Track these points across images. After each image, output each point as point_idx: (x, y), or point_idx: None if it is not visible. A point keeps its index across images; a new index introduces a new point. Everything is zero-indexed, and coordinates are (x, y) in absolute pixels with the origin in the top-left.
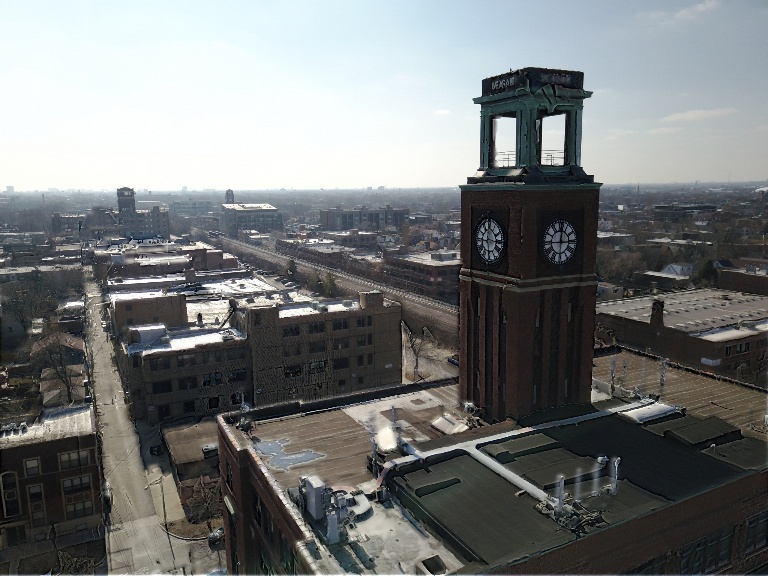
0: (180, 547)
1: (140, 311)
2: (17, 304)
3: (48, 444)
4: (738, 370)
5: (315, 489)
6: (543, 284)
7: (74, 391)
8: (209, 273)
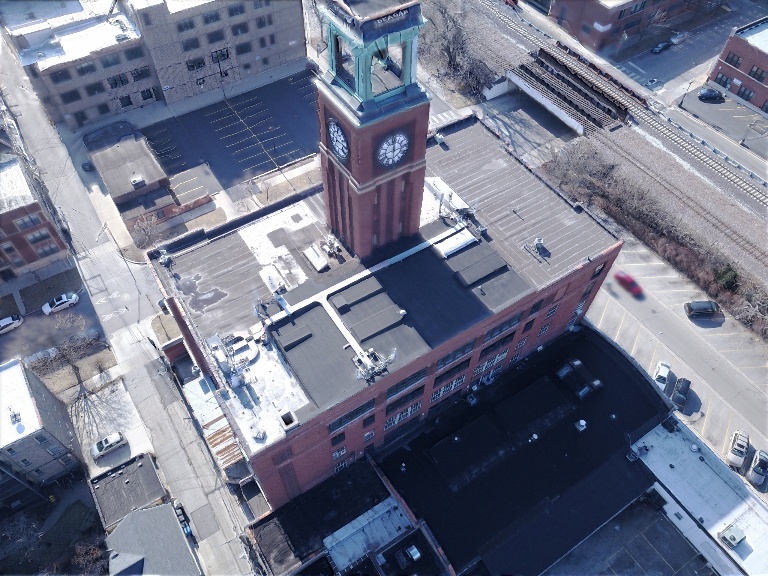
0: (137, 271)
1: None
2: None
3: (1, 217)
4: (623, 37)
5: None
6: (379, 181)
7: None
8: None
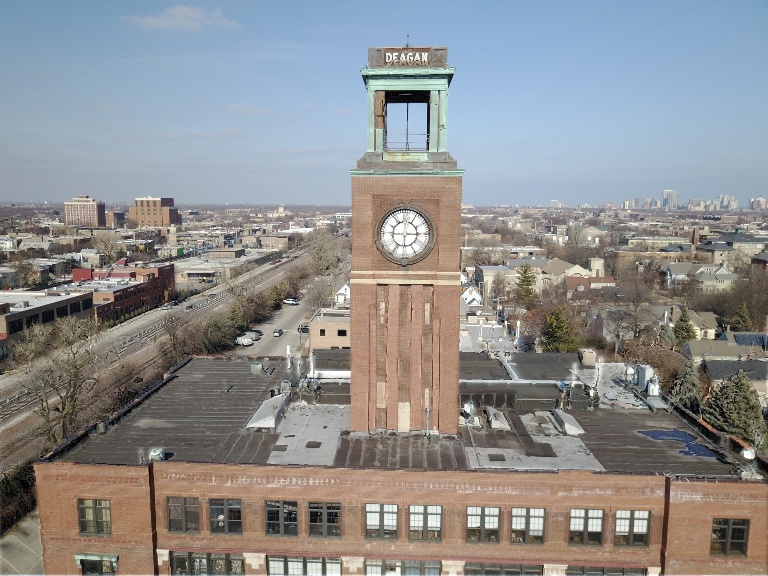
0: None
1: None
2: None
3: None
4: None
5: None
6: None
7: None
8: None
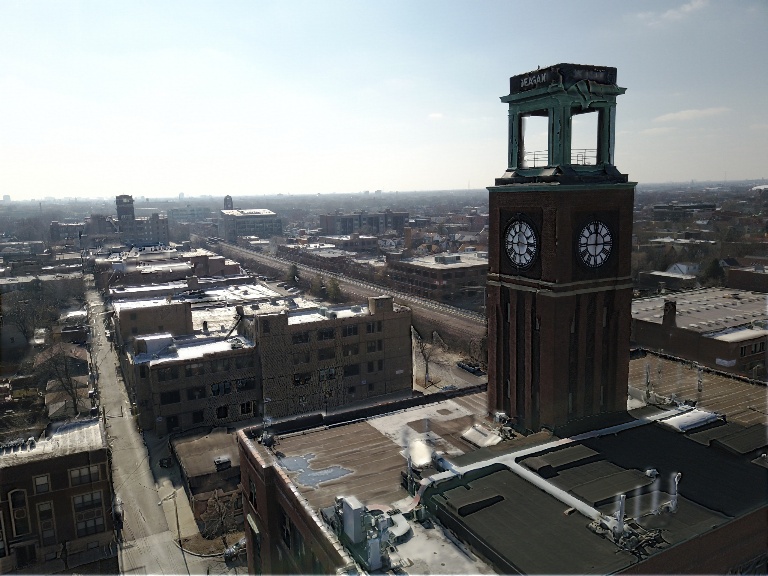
0: (195, 564)
1: (145, 320)
2: (19, 314)
3: (58, 460)
4: (754, 370)
5: (354, 511)
6: (578, 288)
7: (80, 403)
8: (212, 280)
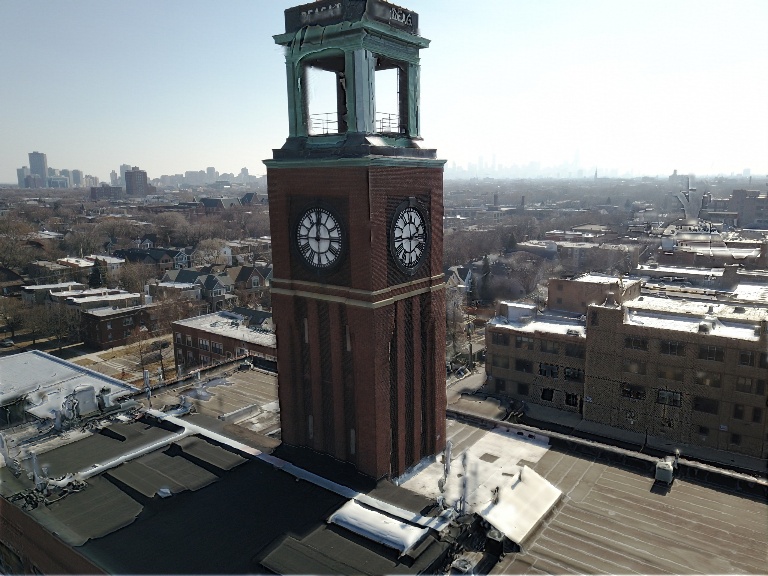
0: None
1: (570, 293)
2: (522, 271)
3: None
4: None
5: None
6: (302, 289)
7: None
8: (759, 273)
